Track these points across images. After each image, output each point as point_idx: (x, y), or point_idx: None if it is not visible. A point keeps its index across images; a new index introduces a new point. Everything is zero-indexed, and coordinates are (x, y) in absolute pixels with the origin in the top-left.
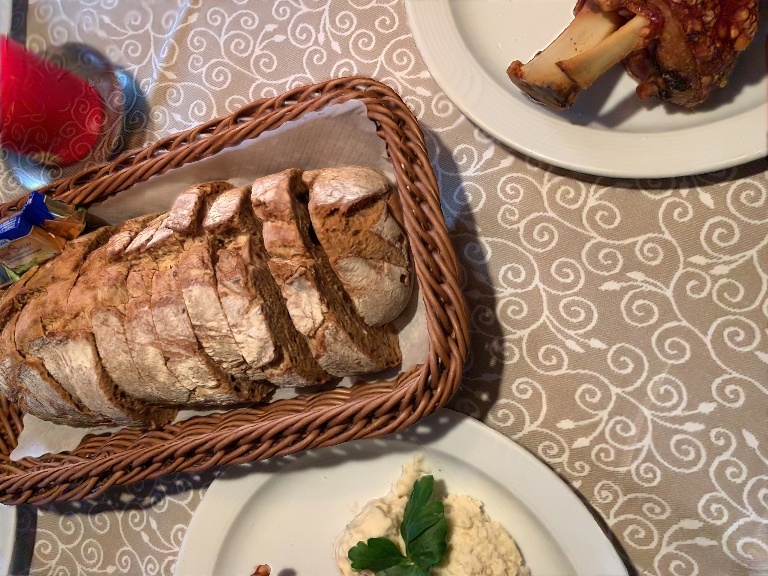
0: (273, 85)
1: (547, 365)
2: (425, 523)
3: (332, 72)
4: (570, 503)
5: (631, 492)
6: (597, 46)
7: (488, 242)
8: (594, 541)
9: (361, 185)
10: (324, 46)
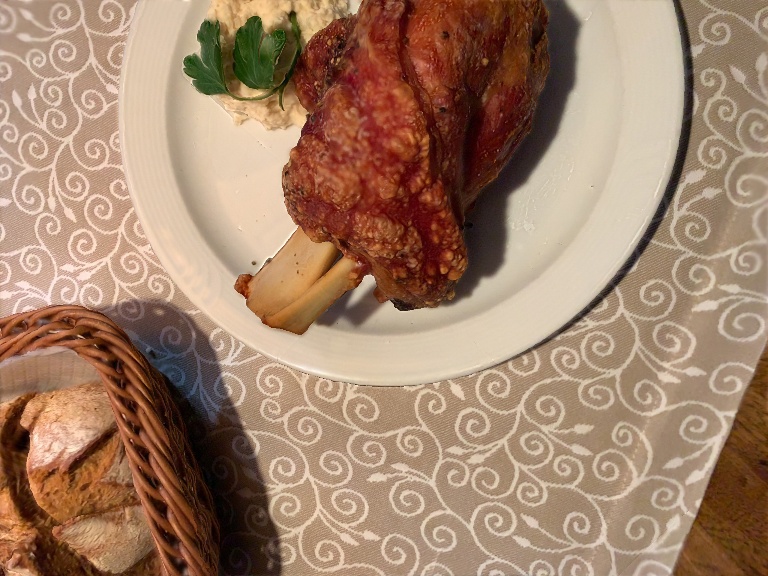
0: (4, 258)
1: (324, 562)
2: None
3: (69, 244)
4: None
5: None
6: (304, 297)
7: (255, 435)
8: None
9: (88, 426)
10: (56, 213)
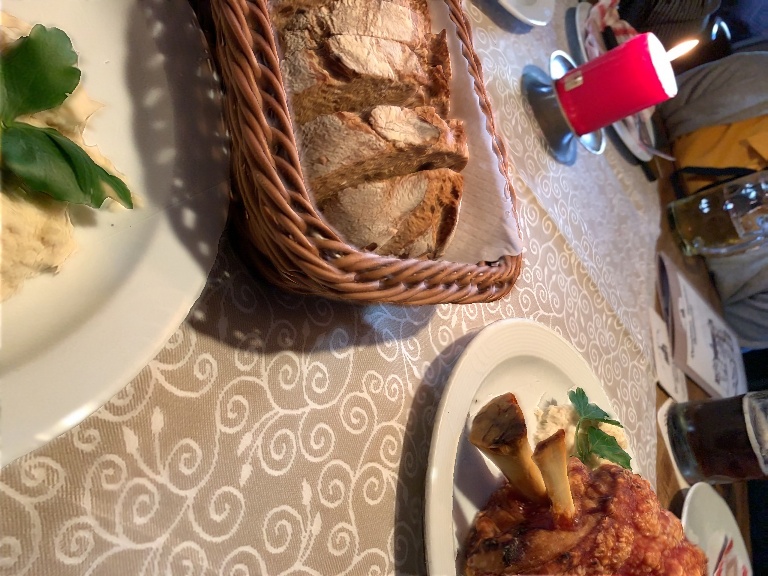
0: None
1: (228, 405)
2: (84, 170)
3: None
4: (79, 407)
5: (43, 516)
6: None
7: (349, 356)
8: (7, 441)
9: None
10: None
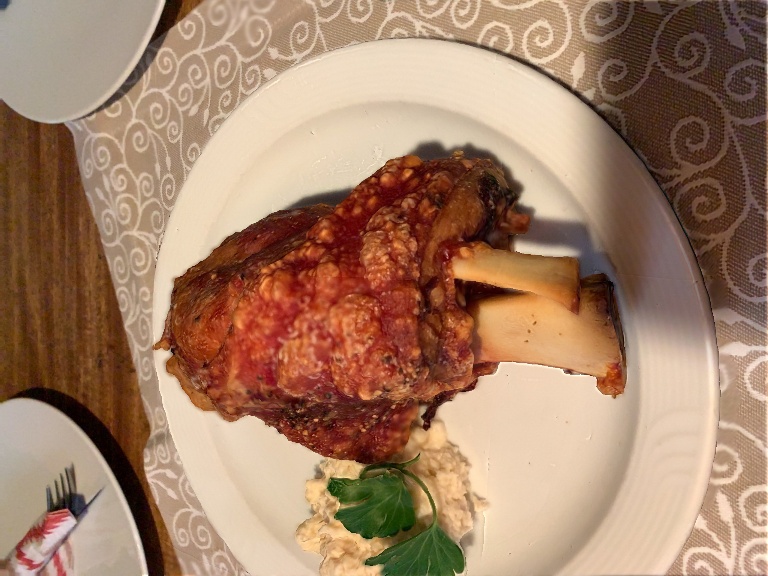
0: None
1: None
2: None
3: None
4: None
5: None
6: (519, 286)
7: None
8: None
9: None
10: None
